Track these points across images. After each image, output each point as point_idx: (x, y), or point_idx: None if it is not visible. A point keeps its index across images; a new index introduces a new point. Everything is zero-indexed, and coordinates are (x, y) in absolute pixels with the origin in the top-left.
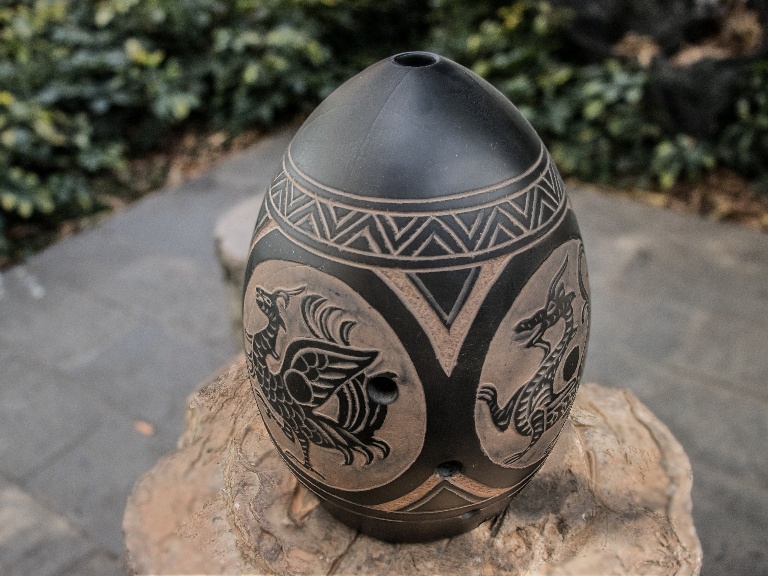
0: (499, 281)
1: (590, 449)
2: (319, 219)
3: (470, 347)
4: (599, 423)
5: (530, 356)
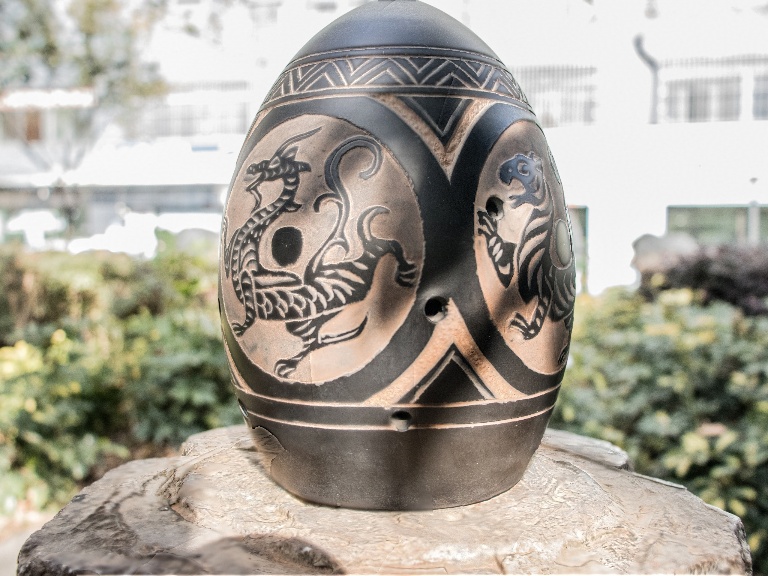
0: (258, 126)
1: (451, 572)
2: None
3: None
4: None
5: None
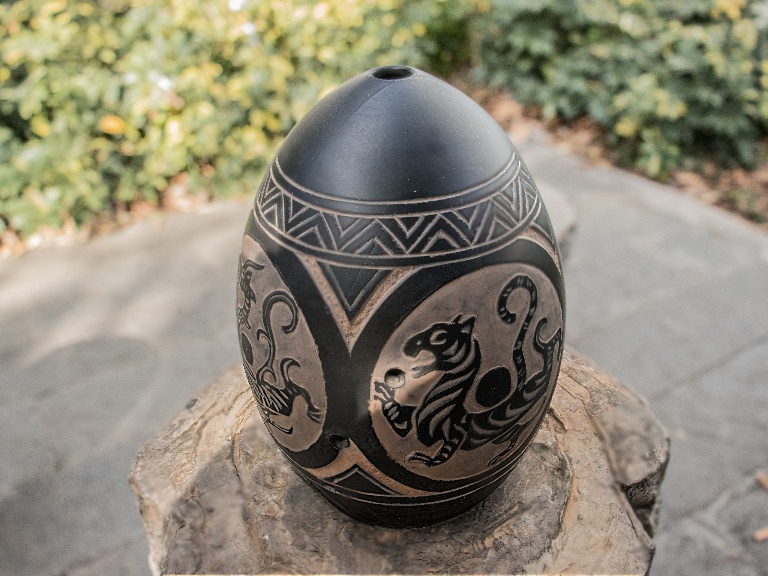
0: None
1: None
2: None
3: None
4: None
5: None
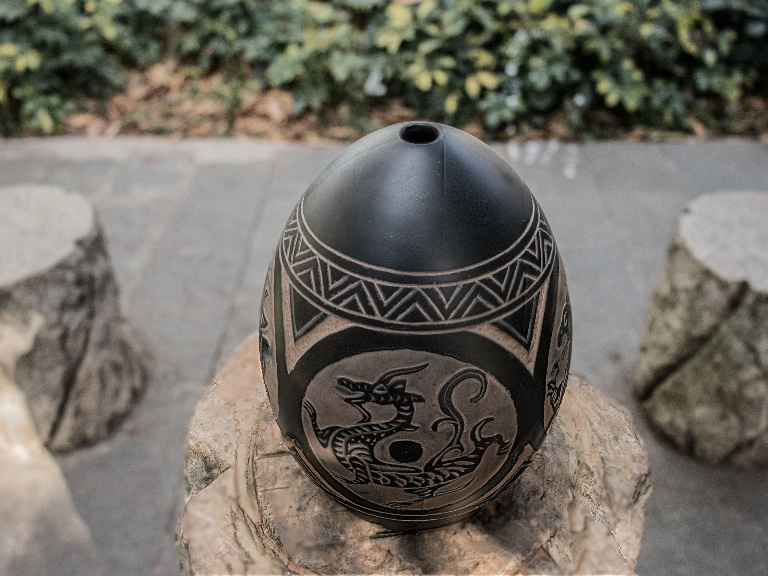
0: (336, 335)
1: (525, 573)
2: (292, 212)
3: (303, 365)
4: (565, 568)
5: (348, 409)
